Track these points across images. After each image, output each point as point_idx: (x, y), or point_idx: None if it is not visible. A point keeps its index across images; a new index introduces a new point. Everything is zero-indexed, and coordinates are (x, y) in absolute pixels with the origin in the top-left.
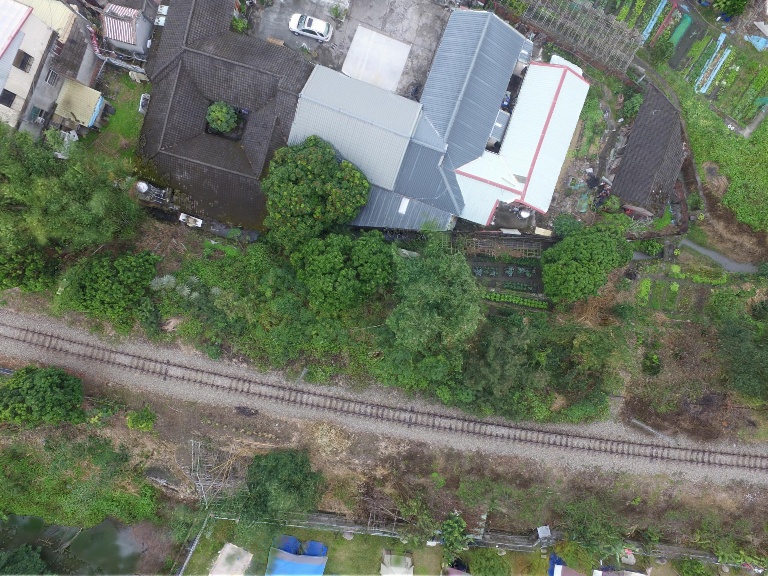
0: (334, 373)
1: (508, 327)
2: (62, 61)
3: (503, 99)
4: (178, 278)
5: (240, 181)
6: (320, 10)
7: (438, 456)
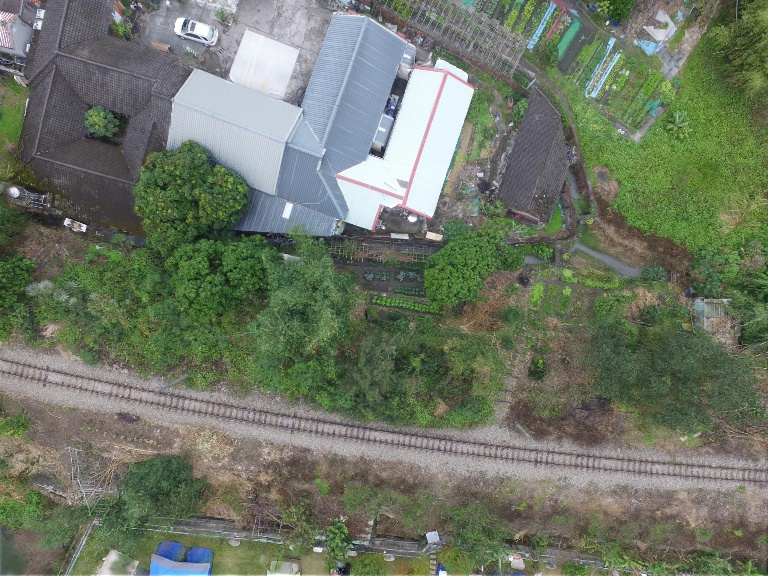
0: (215, 379)
1: (394, 332)
2: None
3: (390, 103)
4: (56, 284)
5: (118, 186)
6: (207, 14)
7: (322, 462)
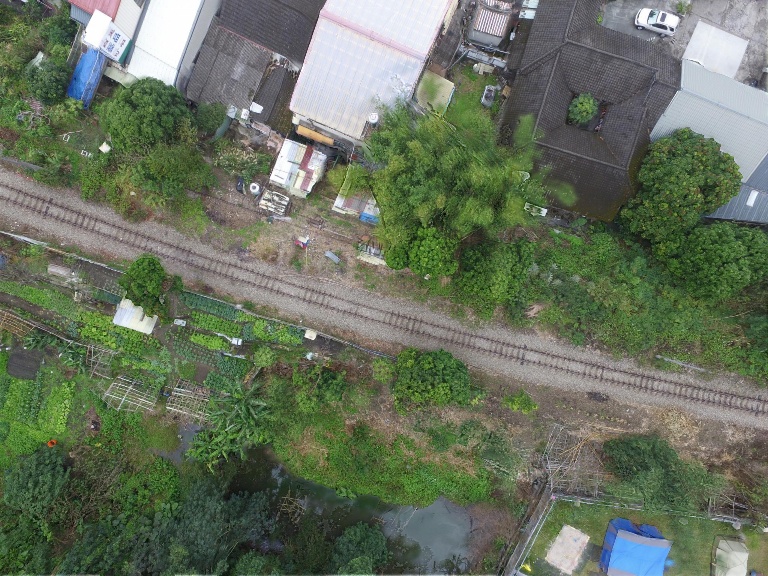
0: (688, 361)
1: None
2: (439, 52)
3: None
4: (541, 265)
5: (605, 171)
6: (662, 5)
7: None
